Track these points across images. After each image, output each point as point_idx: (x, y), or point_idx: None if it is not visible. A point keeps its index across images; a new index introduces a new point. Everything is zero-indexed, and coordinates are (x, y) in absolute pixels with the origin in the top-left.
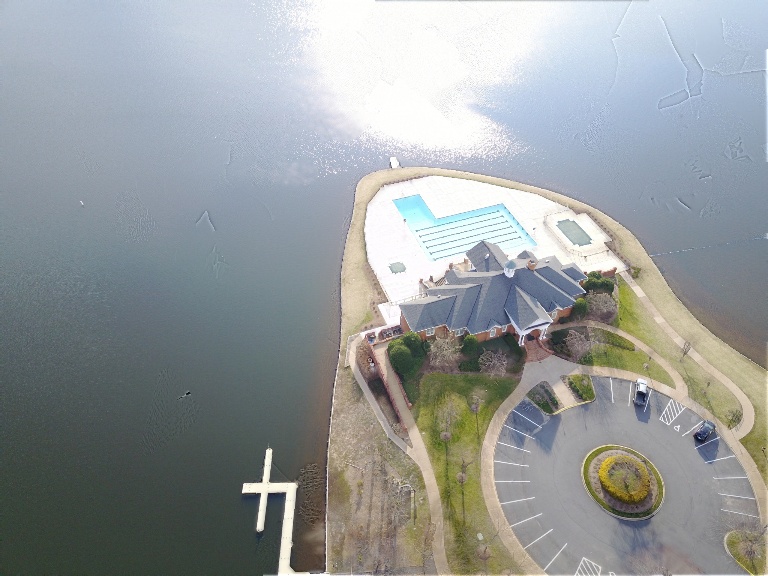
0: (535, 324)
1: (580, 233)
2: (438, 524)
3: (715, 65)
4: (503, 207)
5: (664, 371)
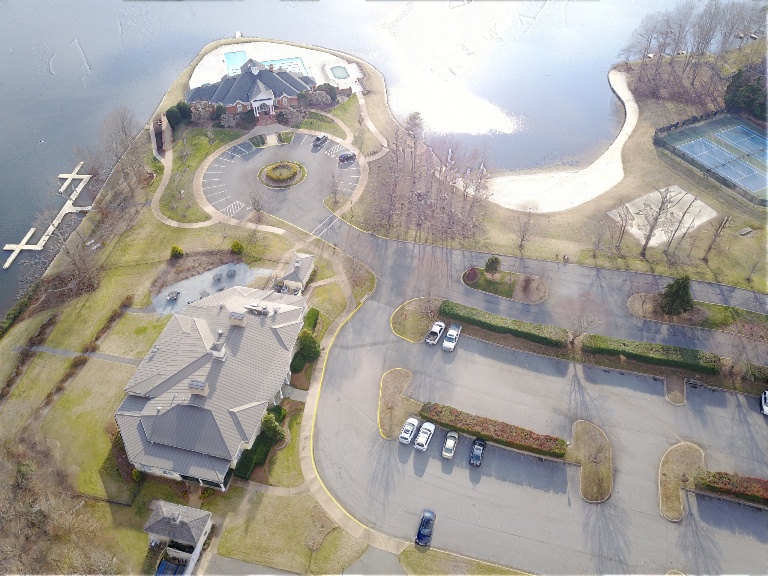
0: (261, 99)
1: (344, 73)
2: (162, 188)
3: None
4: (300, 59)
5: (344, 133)
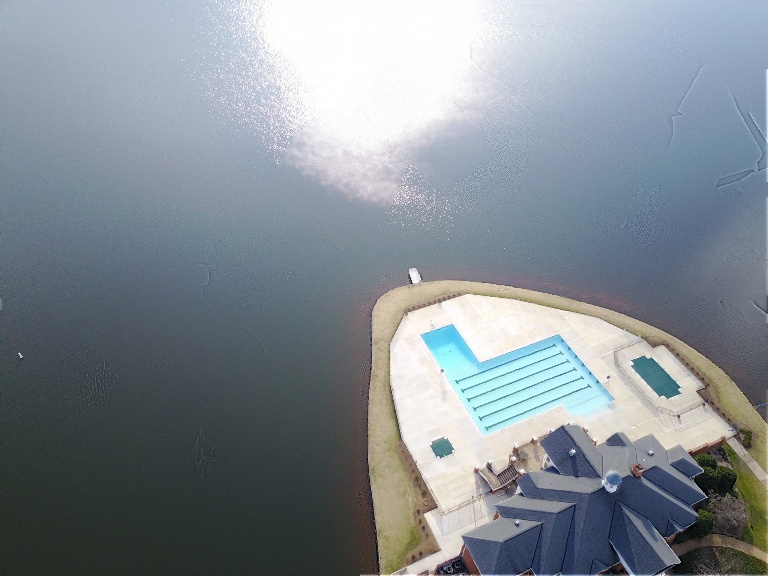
0: None
1: (663, 377)
2: None
3: (767, 127)
4: (560, 339)
5: None
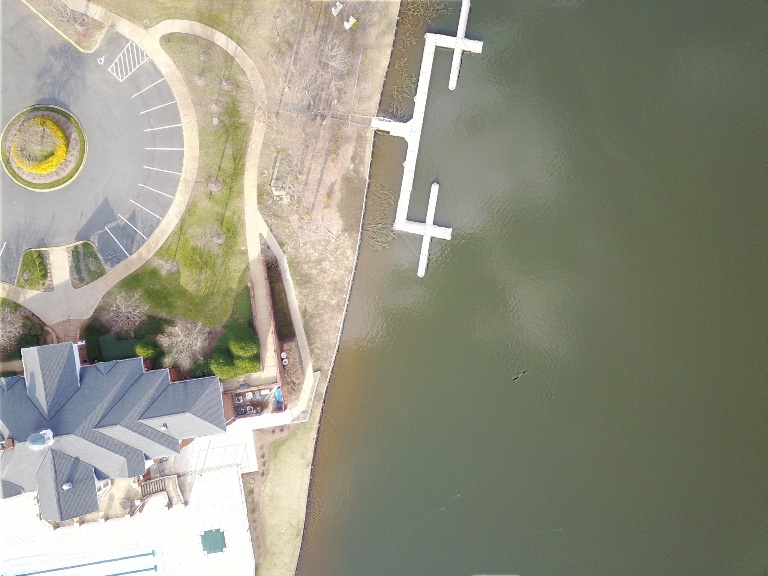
0: None
1: None
2: (255, 145)
3: None
4: None
5: None
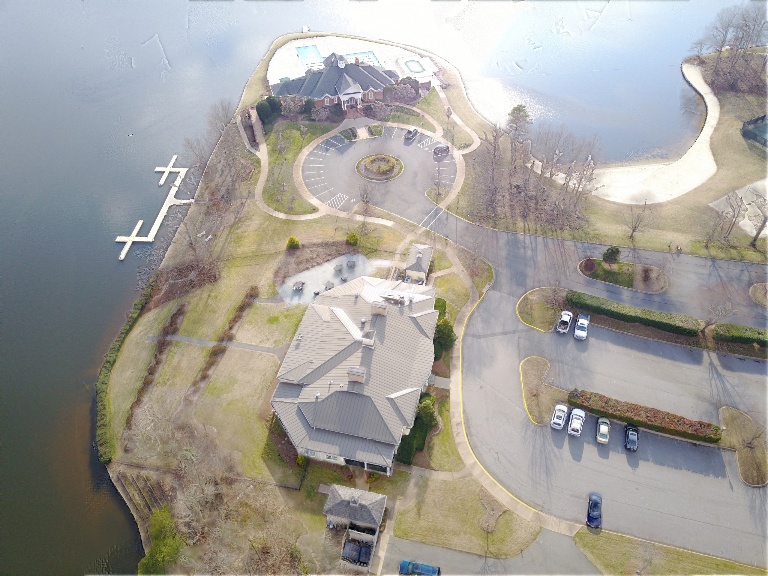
0: (350, 92)
1: (418, 67)
2: (263, 181)
3: None
4: (372, 53)
5: (433, 126)
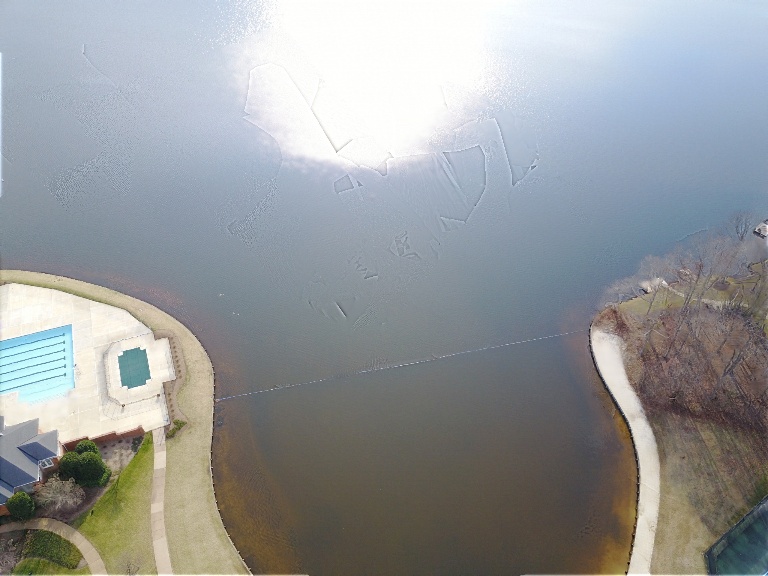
0: None
1: (141, 368)
2: None
3: (430, 136)
4: (71, 329)
5: None
